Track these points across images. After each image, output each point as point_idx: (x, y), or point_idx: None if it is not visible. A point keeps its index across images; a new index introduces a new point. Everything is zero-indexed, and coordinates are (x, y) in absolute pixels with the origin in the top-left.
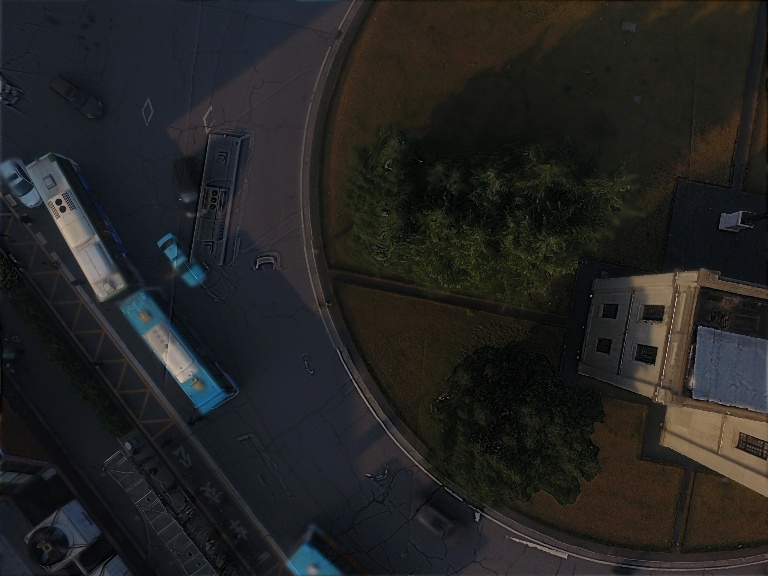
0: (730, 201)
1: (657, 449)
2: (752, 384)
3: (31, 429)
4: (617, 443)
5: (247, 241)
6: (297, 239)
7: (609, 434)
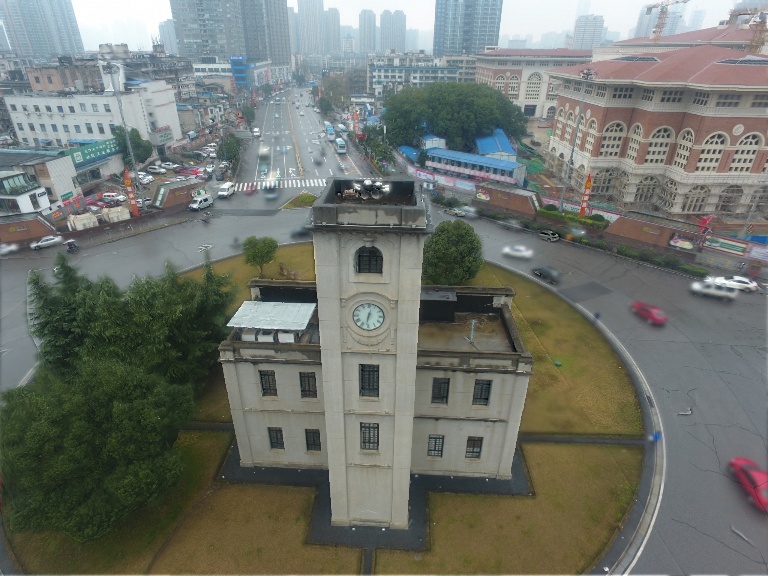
0: None
1: (329, 532)
2: None
3: None
4: (277, 529)
5: None
6: (0, 402)
7: (268, 520)
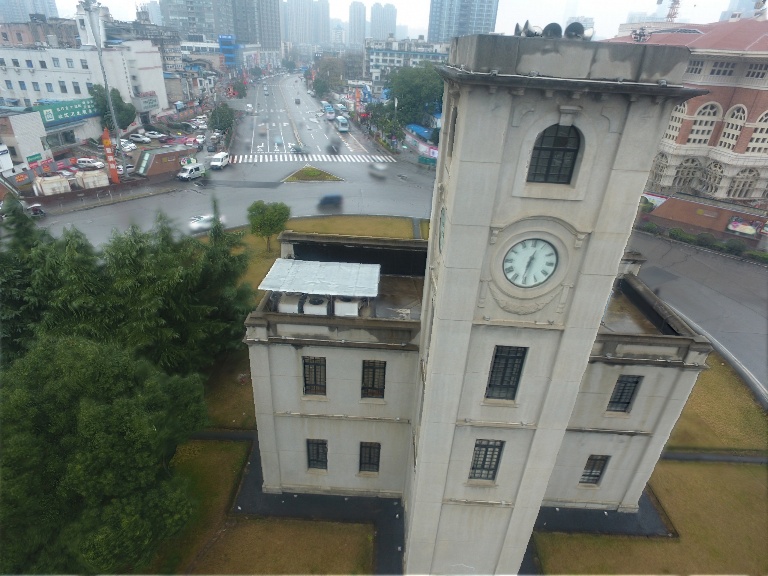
0: None
1: None
2: (335, 282)
3: None
4: None
5: None
6: None
7: None
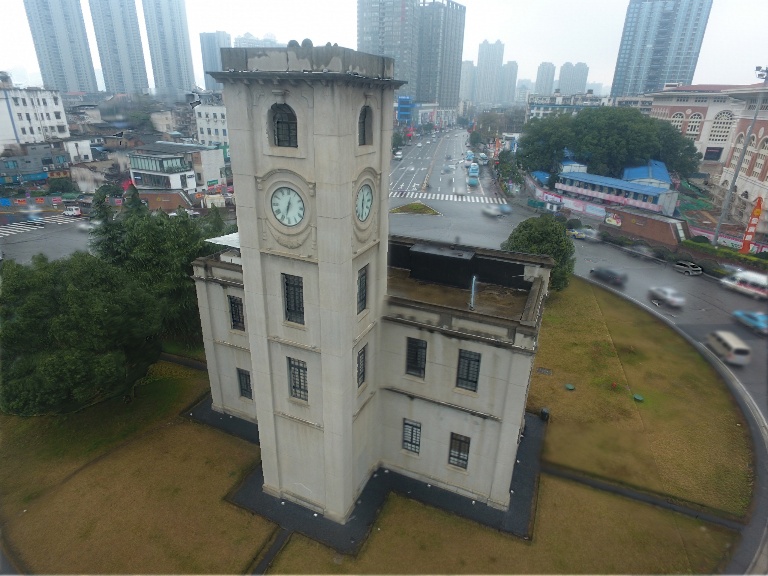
0: None
1: (256, 497)
2: None
3: None
4: (207, 476)
5: None
6: None
7: (204, 465)
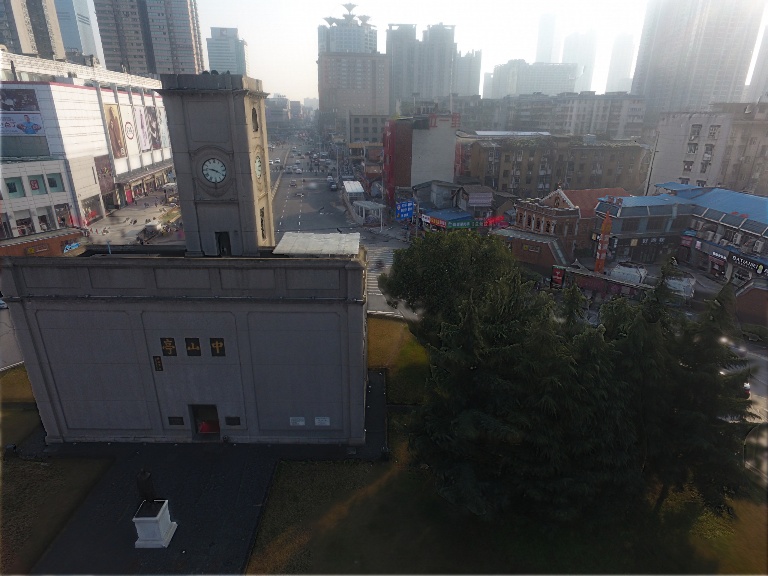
0: (143, 571)
1: None
2: None
3: (759, 317)
4: None
5: (767, 429)
6: None
7: None
